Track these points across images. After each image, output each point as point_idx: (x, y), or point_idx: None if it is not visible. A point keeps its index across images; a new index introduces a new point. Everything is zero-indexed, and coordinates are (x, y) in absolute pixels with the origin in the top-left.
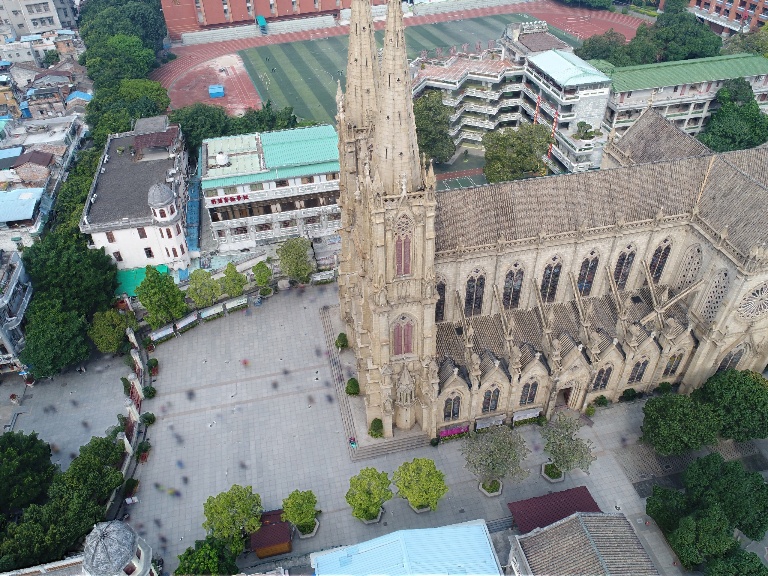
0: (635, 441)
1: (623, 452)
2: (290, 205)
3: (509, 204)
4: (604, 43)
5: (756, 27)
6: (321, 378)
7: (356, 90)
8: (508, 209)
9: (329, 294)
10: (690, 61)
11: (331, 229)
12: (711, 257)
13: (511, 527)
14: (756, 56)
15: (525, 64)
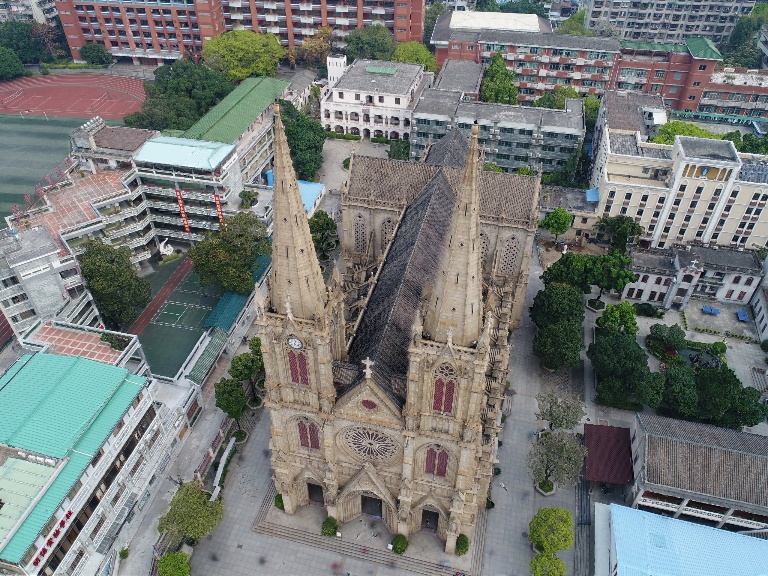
0: (539, 377)
1: (545, 389)
2: (112, 472)
3: (418, 287)
4: (161, 114)
5: (186, 51)
6: (359, 573)
7: (308, 280)
8: (420, 291)
9: (237, 511)
10: (230, 101)
11: (155, 455)
12: (498, 233)
13: (588, 492)
14: (264, 79)
15: (133, 166)
